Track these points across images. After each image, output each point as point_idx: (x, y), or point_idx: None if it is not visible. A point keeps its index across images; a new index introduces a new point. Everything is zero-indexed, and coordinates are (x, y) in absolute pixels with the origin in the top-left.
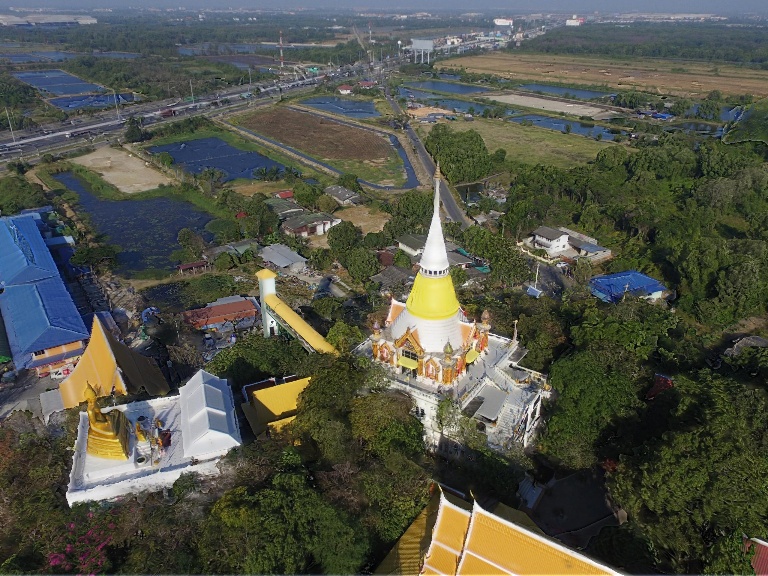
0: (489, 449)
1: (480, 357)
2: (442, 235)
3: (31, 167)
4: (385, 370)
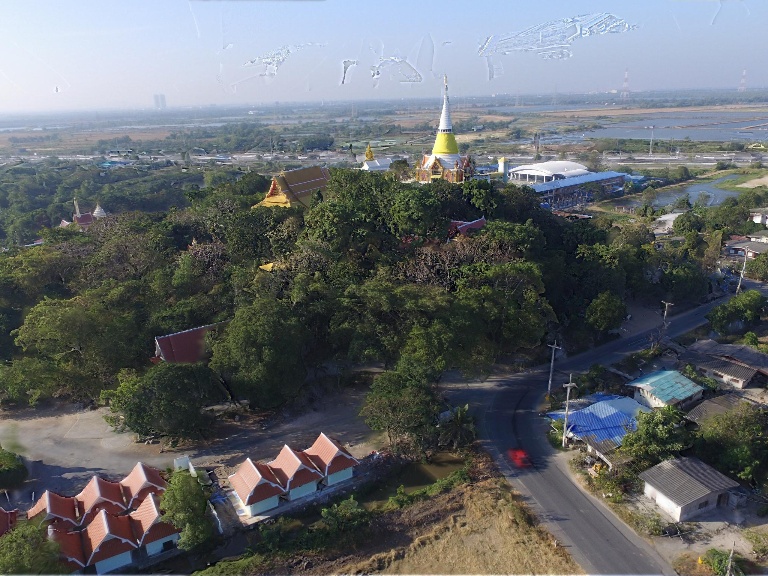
0: None
1: None
2: (445, 112)
3: (735, 168)
4: (415, 170)
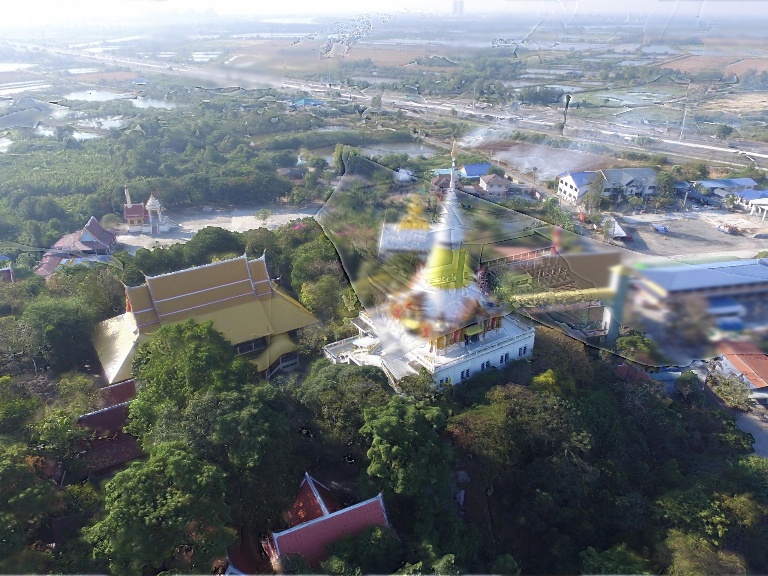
0: (326, 332)
1: (426, 345)
2: None
3: None
4: None
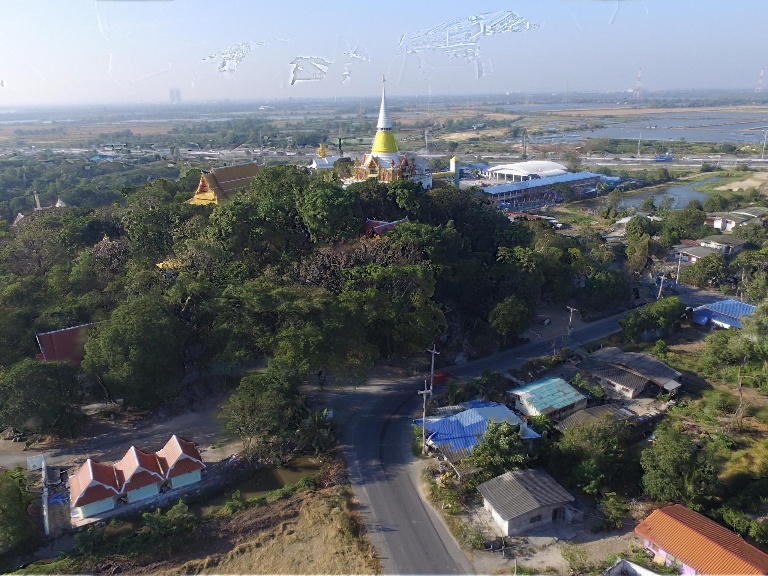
0: None
1: None
2: (383, 110)
3: (720, 170)
4: None
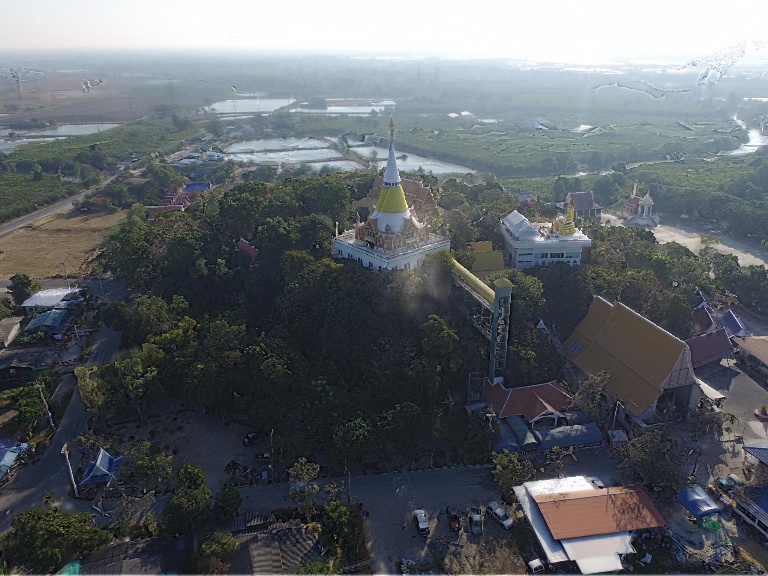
0: None
1: None
2: None
3: None
4: None
